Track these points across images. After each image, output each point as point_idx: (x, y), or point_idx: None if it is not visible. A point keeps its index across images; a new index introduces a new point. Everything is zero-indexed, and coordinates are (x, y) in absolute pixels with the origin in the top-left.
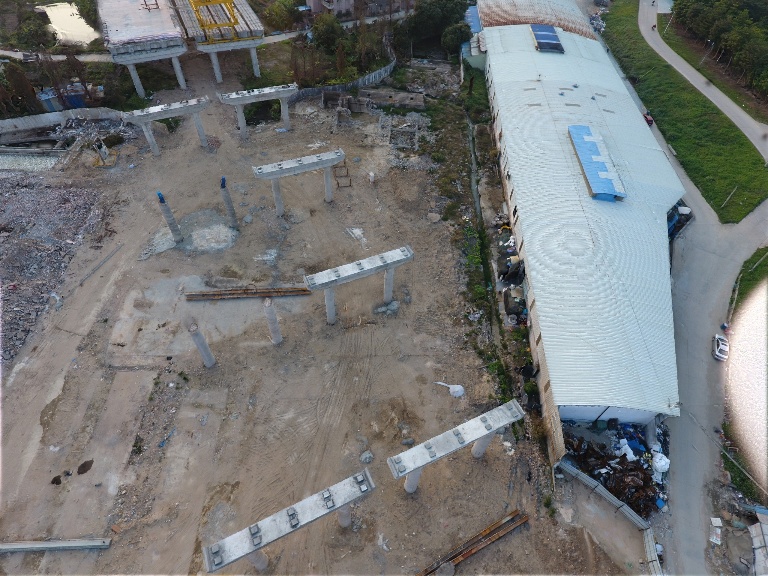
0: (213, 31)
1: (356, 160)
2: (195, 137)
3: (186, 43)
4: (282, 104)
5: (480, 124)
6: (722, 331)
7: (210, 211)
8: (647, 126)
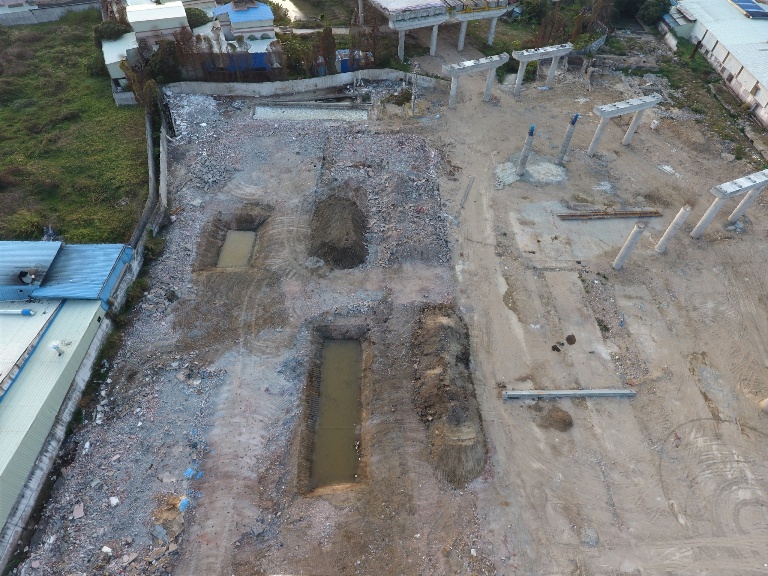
0: (468, 1)
1: None
2: (474, 94)
3: (448, 12)
4: (555, 63)
5: (713, 83)
6: None
7: None
8: None
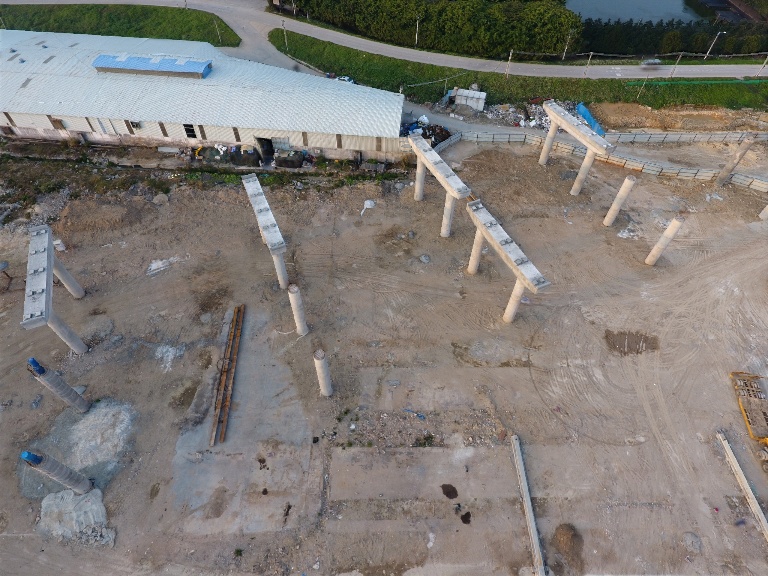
0: None
1: (4, 266)
2: None
3: None
4: None
5: (1, 148)
6: (331, 78)
7: None
8: (108, 36)
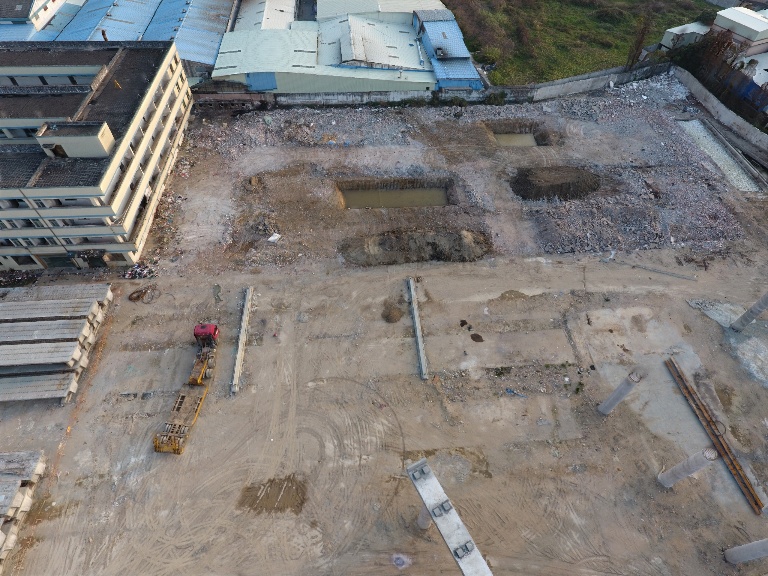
0: None
1: None
2: None
3: None
4: None
5: None
6: None
7: None
8: None
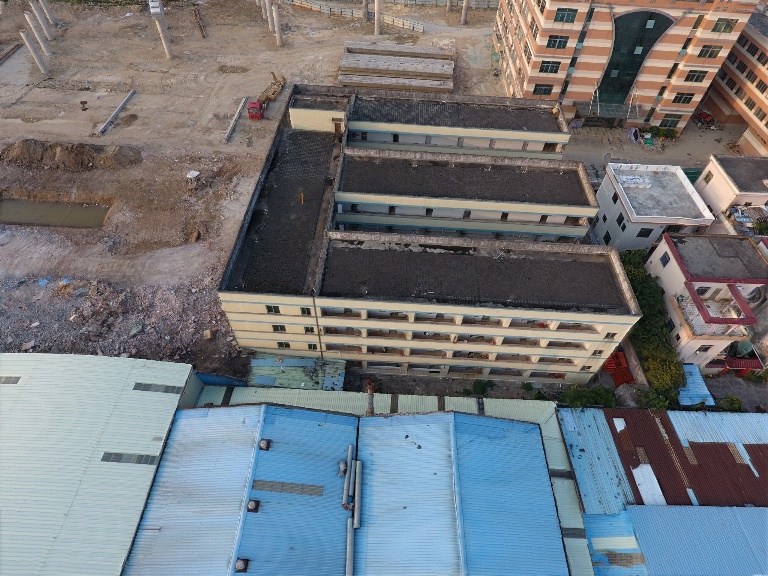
0: None
1: None
2: None
3: None
4: None
5: None
6: None
7: None
8: None
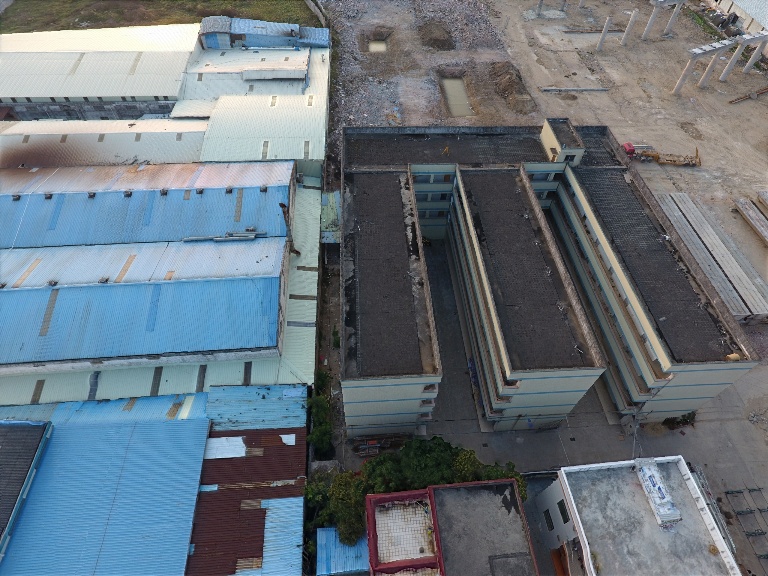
0: None
1: None
2: None
3: None
4: None
5: None
6: None
7: (542, 5)
8: None
